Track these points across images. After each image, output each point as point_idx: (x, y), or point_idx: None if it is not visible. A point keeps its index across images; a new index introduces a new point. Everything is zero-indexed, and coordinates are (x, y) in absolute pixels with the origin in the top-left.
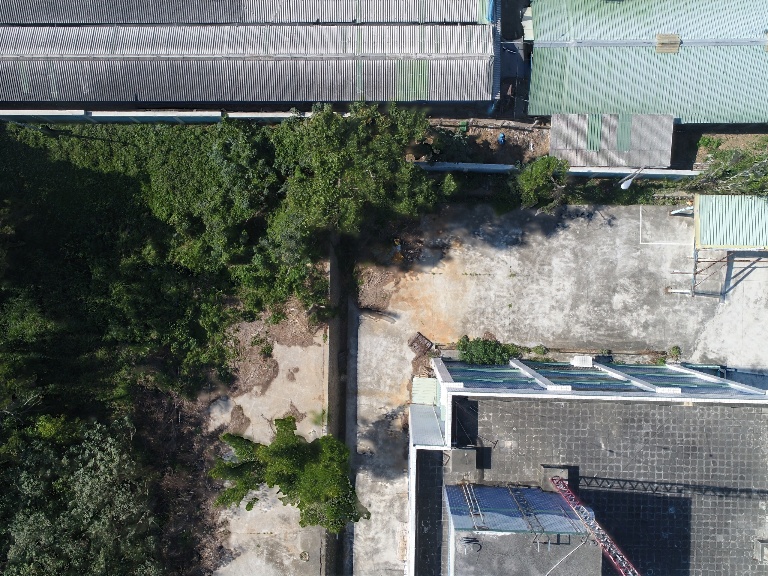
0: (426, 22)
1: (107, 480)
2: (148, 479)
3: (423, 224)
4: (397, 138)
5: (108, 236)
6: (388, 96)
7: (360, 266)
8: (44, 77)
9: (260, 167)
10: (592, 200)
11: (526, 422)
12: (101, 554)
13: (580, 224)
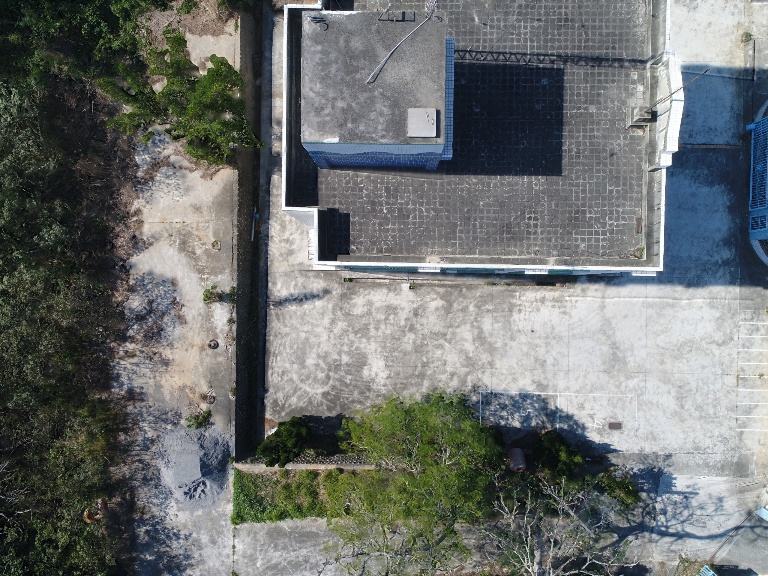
0: None
1: (6, 116)
2: (58, 156)
3: None
4: None
5: None
6: None
7: None
8: None
9: None
10: None
11: None
12: (5, 206)
13: None
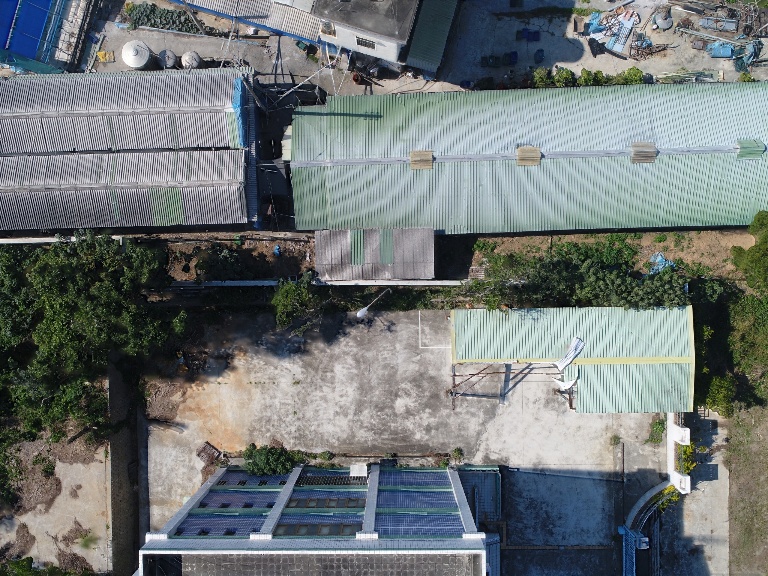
0: (180, 148)
1: None
2: None
3: (207, 335)
4: (122, 281)
5: None
6: (146, 222)
7: (146, 378)
8: None
9: (23, 295)
10: (371, 307)
11: (228, 571)
12: None
13: (360, 331)
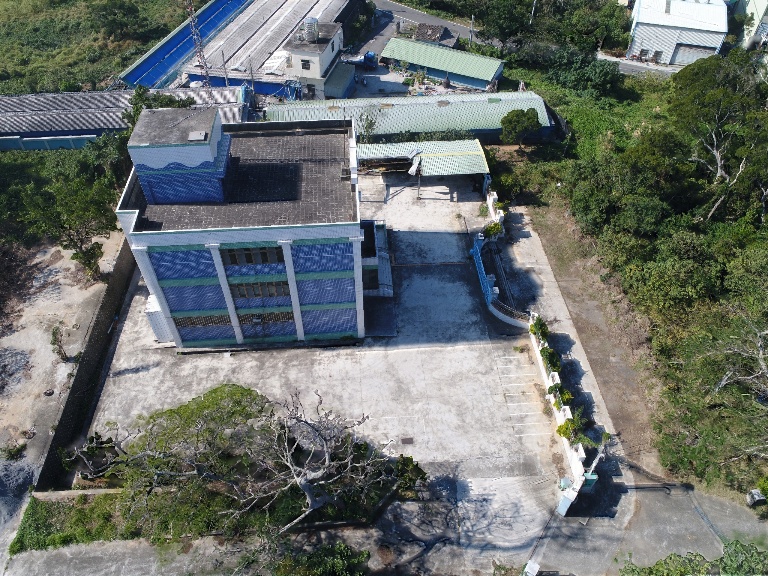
0: None
1: None
2: None
3: None
4: None
5: (8, 180)
6: None
7: None
8: (4, 123)
9: None
10: None
11: None
12: None
13: None
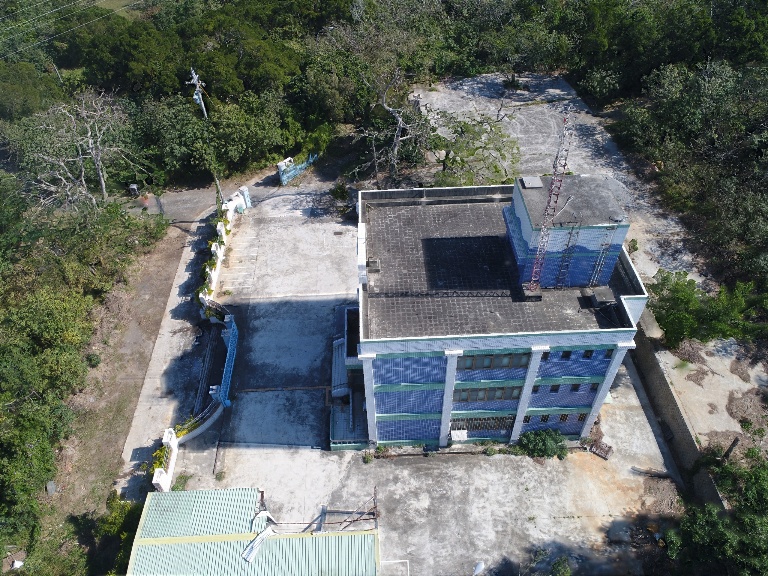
0: None
1: None
2: None
3: (639, 567)
4: None
5: None
6: None
7: None
8: None
9: None
10: None
11: (561, 325)
12: None
13: None
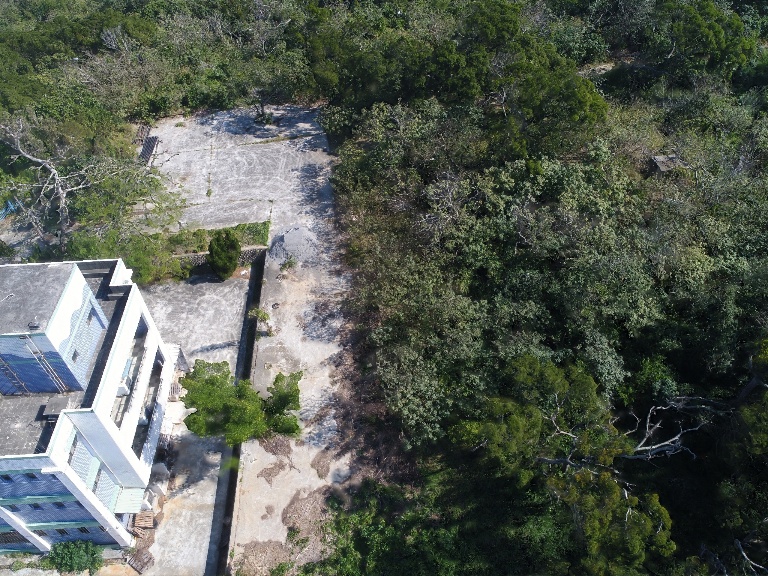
0: None
1: None
2: None
3: None
4: None
5: None
6: None
7: None
8: None
9: None
10: None
11: None
12: (412, 341)
13: None
